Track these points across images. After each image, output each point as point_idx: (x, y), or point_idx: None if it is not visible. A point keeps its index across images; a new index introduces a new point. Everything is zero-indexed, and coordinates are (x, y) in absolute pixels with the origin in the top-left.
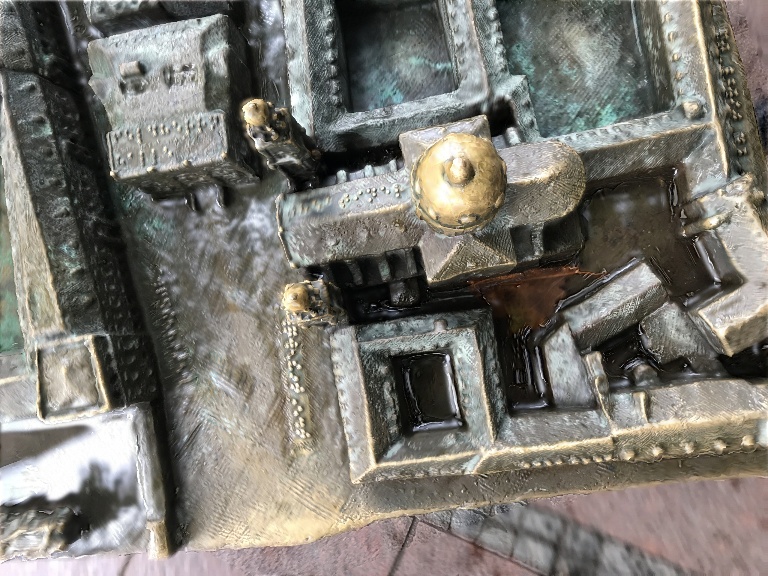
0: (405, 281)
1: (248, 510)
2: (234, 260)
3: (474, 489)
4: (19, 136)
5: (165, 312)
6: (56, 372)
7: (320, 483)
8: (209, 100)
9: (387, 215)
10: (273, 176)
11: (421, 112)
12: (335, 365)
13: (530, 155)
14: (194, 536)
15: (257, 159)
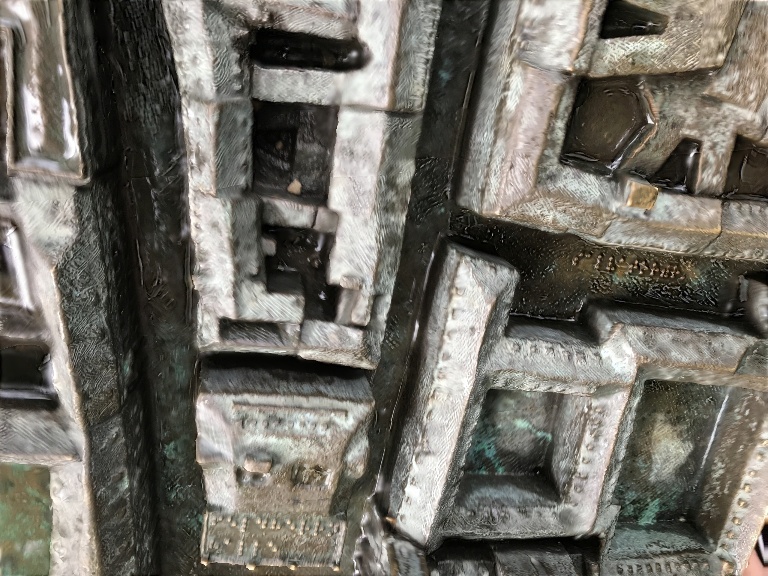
0: None
1: None
2: (278, 567)
3: None
4: (97, 514)
5: None
6: None
7: None
8: (334, 503)
9: None
10: None
11: (526, 532)
12: None
13: None
14: None
15: None
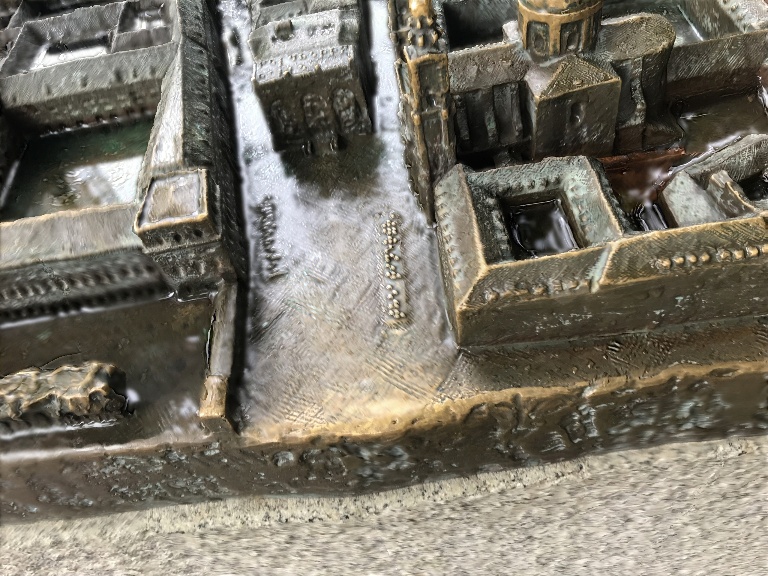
0: (510, 151)
1: (325, 391)
2: (340, 185)
3: (604, 363)
4: (185, 62)
5: (266, 224)
6: (163, 196)
7: (414, 361)
8: (341, 41)
9: (495, 52)
10: (383, 130)
11: None
12: (440, 206)
13: (620, 18)
14: (255, 420)
15: (370, 117)
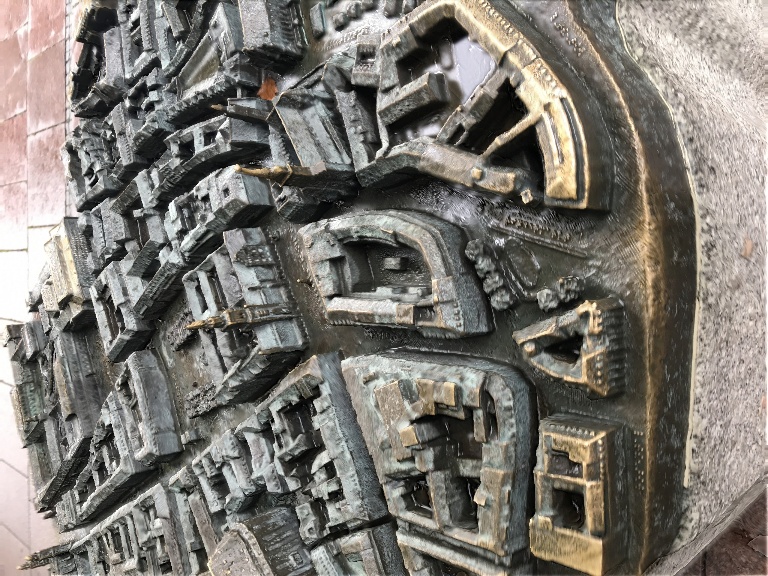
0: None
1: None
2: None
3: None
4: (52, 483)
5: None
6: None
7: None
8: None
9: None
10: None
11: (78, 575)
12: None
13: None
14: None
15: None
